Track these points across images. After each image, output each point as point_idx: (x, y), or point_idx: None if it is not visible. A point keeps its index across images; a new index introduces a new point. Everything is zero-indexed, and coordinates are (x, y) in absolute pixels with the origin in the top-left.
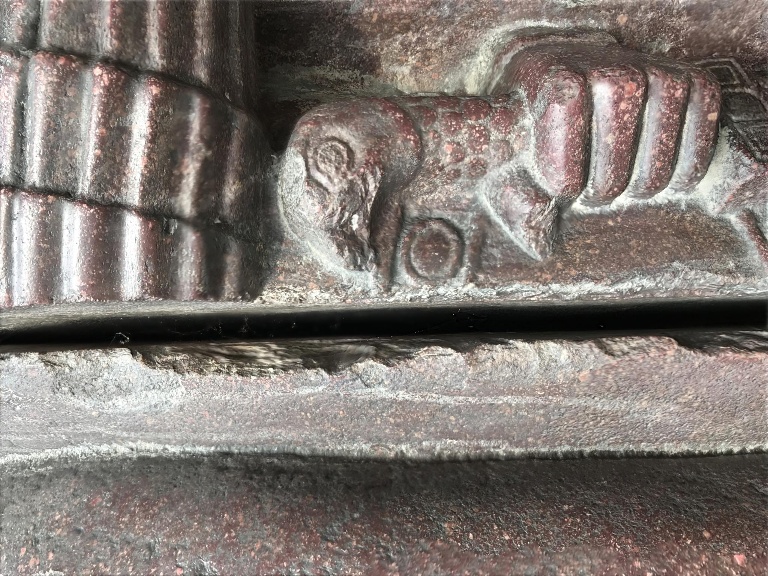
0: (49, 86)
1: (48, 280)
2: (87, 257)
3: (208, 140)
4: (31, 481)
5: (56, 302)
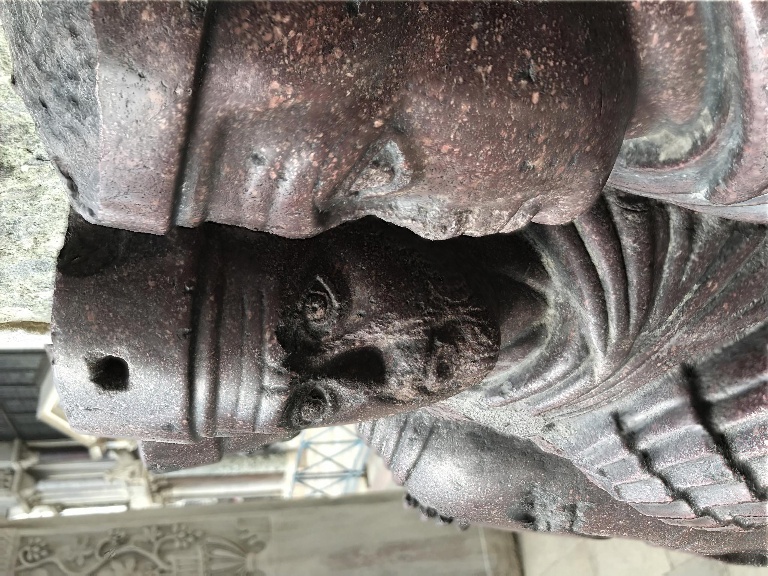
0: None
1: None
2: None
3: None
4: None
5: None
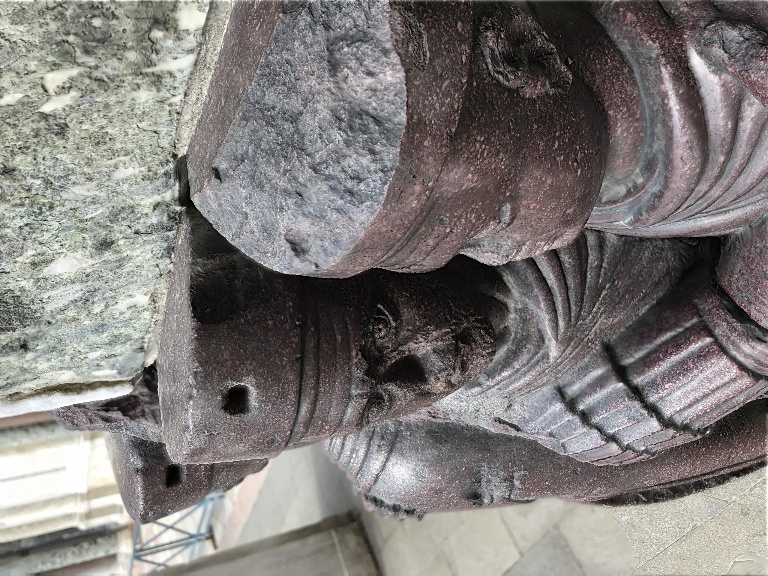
0: None
1: None
2: None
3: None
4: (507, 436)
5: None
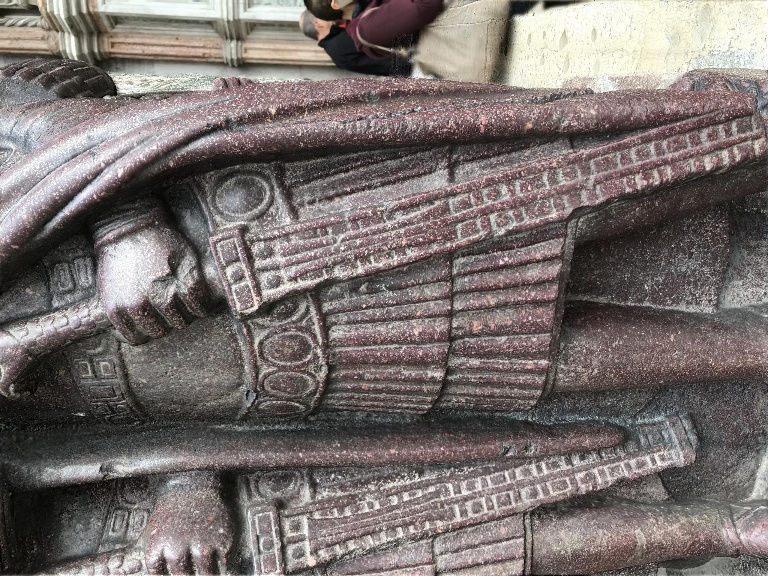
0: (37, 59)
1: (9, 74)
2: (26, 72)
3: (78, 81)
4: None
5: (7, 78)
